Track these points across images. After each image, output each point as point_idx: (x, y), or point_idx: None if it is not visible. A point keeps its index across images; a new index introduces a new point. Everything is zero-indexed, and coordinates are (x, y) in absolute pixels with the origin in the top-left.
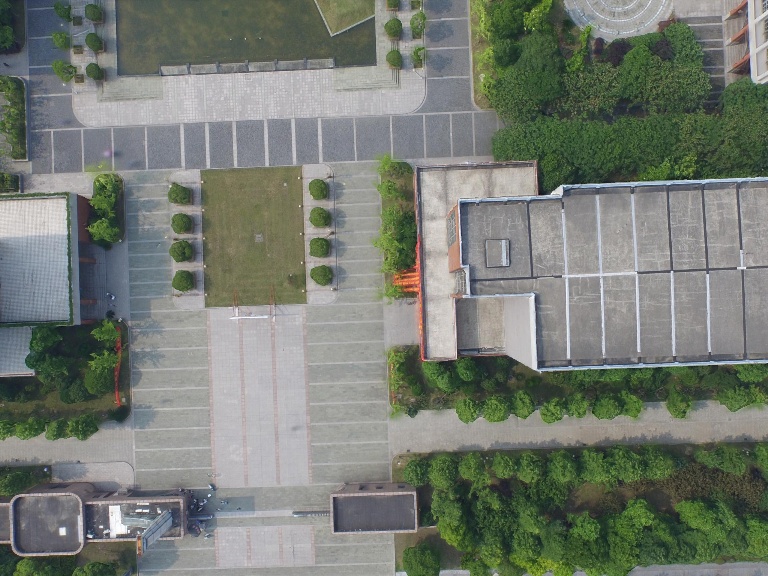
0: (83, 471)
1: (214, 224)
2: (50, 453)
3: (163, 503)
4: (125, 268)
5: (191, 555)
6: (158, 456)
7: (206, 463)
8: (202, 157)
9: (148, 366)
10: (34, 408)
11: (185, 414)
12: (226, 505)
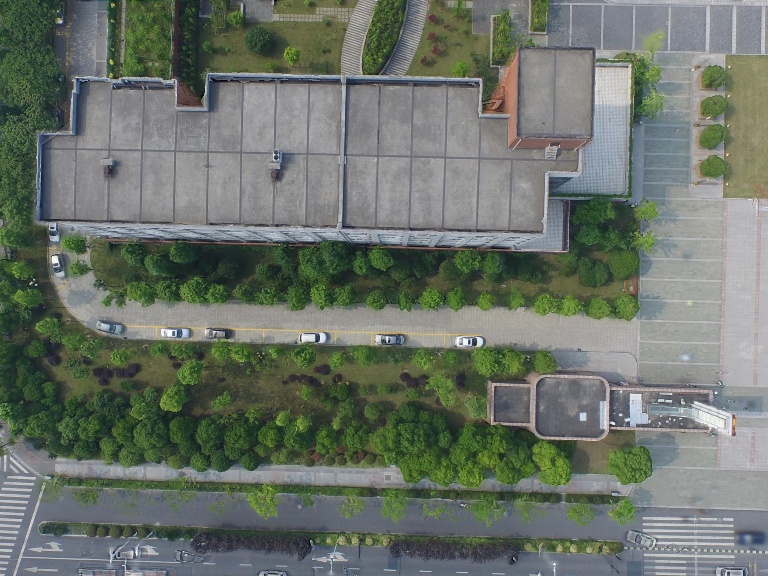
0: (584, 360)
1: (738, 112)
2: (550, 339)
3: (688, 394)
4: (640, 152)
5: (691, 453)
6: (663, 349)
7: (714, 359)
8: (728, 41)
9: (659, 255)
10: (537, 291)
11: (695, 307)
12: (732, 404)
